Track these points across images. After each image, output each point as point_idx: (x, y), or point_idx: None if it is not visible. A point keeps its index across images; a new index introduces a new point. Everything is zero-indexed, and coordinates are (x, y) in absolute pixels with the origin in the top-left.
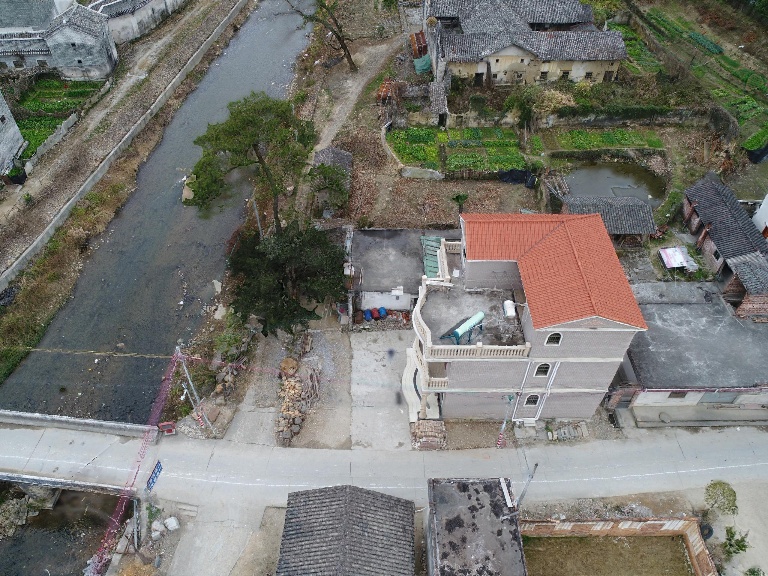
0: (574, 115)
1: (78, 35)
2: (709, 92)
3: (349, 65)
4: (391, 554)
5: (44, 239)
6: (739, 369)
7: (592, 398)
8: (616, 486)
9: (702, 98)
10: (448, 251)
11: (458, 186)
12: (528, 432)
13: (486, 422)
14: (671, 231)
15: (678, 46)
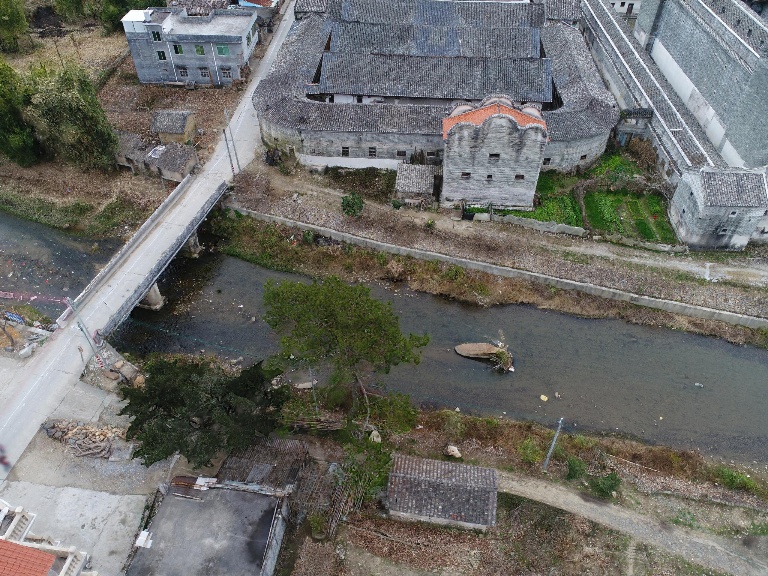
0: None
1: (700, 190)
2: None
3: None
4: None
5: (392, 249)
6: None
7: None
8: None
9: None
10: None
11: None
12: None
13: None
14: None
15: None
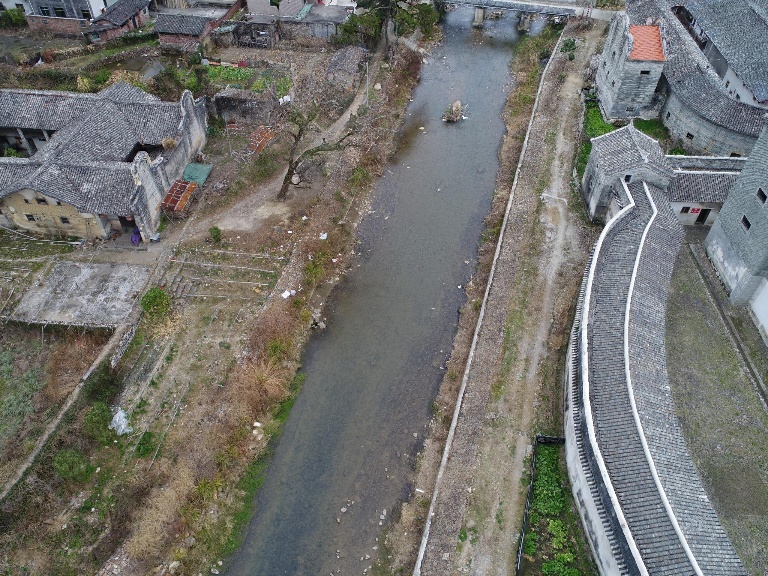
0: None
1: None
2: None
3: (285, 203)
4: None
5: None
6: None
7: None
8: None
9: None
10: None
11: None
12: None
13: None
14: None
15: None
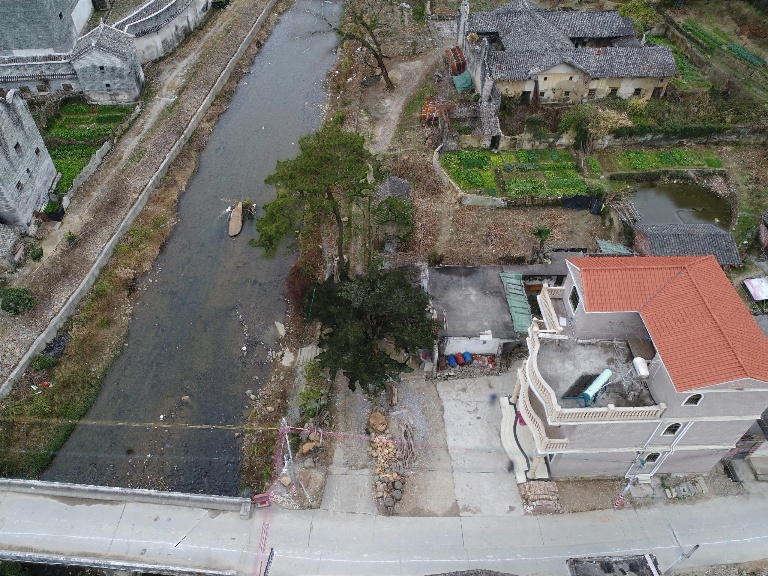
0: (631, 135)
1: (107, 58)
2: (766, 109)
3: (385, 83)
4: None
5: (90, 281)
6: None
7: (715, 454)
8: (748, 549)
9: (759, 115)
10: (549, 296)
11: (521, 214)
12: (644, 490)
13: (598, 480)
14: (749, 259)
15: (718, 58)
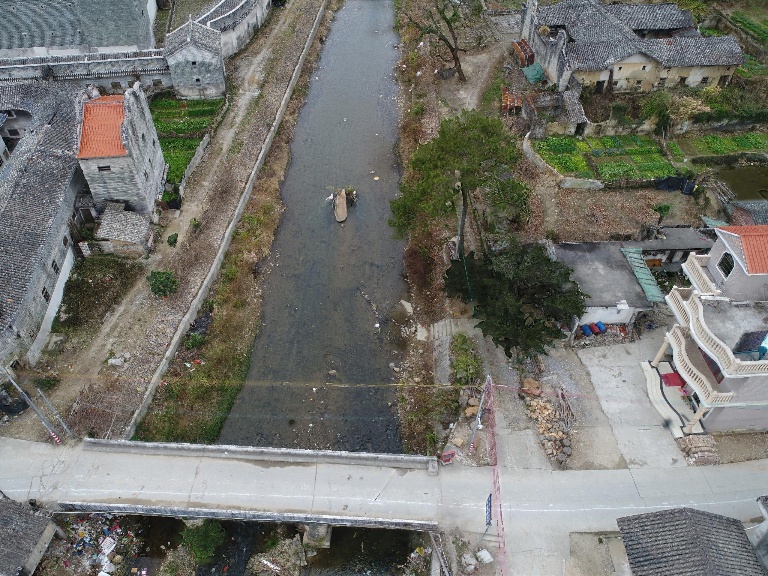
0: (708, 120)
1: (200, 53)
2: None
3: (456, 76)
4: (748, 575)
5: (218, 265)
6: None
7: None
8: None
9: None
10: None
11: (618, 195)
12: None
13: (748, 433)
14: None
15: None
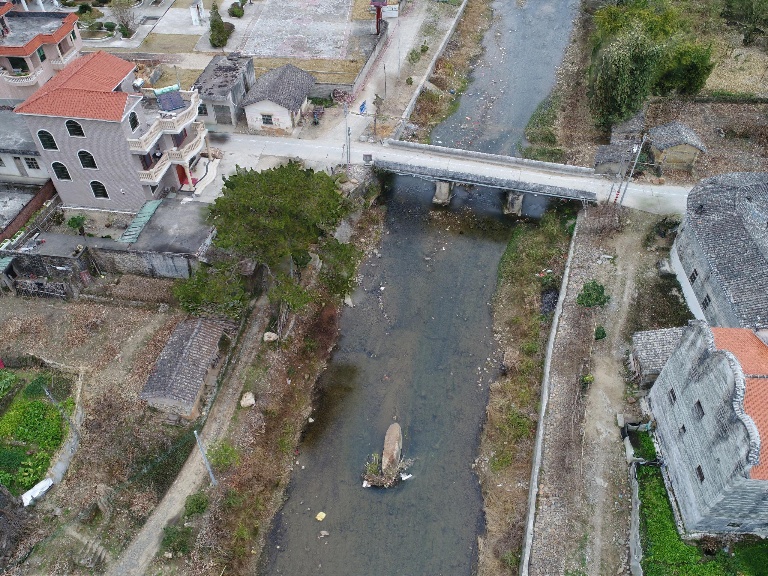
0: None
1: None
2: None
3: None
4: None
5: None
6: (8, 117)
7: None
8: None
9: None
10: None
11: None
12: None
13: None
14: None
15: None
